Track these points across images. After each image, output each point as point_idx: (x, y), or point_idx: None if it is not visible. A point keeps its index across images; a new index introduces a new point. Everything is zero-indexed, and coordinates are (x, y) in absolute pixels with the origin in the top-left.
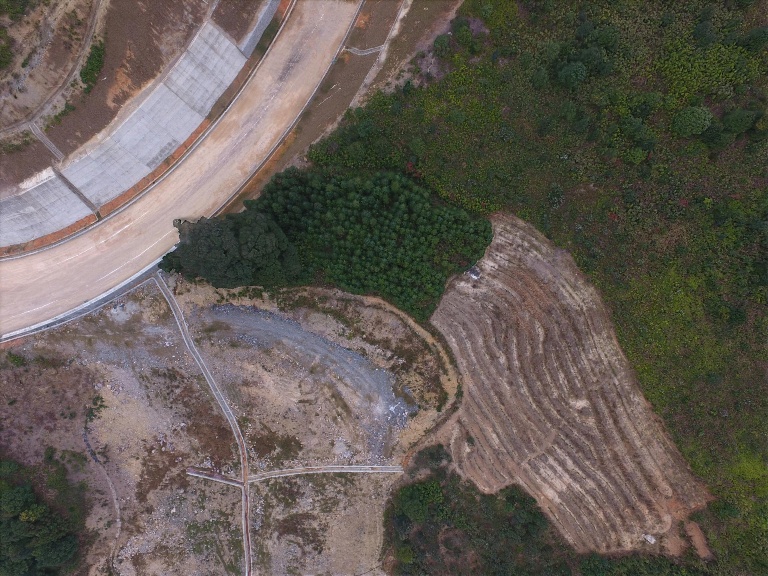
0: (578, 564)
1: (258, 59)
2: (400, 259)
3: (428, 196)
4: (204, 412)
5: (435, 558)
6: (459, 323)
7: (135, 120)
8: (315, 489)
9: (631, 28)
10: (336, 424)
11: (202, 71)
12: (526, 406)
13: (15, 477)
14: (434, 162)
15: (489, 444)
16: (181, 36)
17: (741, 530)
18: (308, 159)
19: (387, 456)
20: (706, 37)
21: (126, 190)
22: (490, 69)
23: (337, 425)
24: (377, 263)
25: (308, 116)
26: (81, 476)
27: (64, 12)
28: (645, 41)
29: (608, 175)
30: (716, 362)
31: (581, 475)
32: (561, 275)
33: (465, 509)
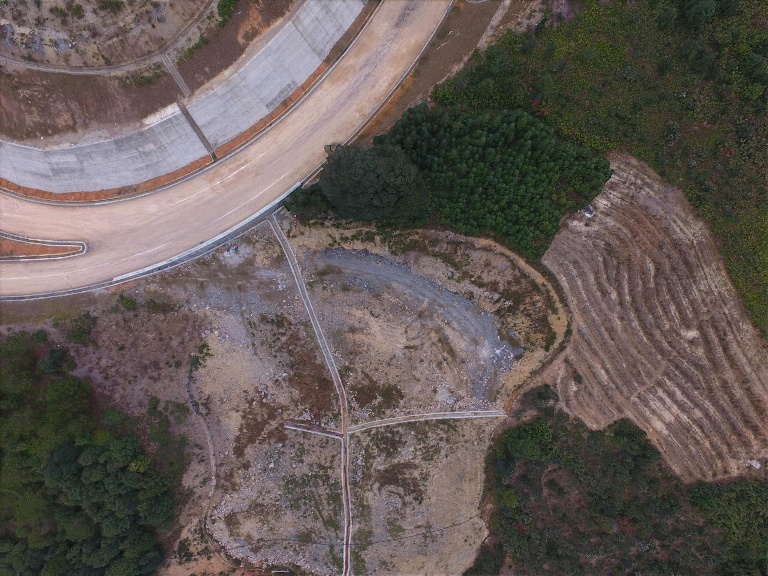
0: (687, 493)
1: (374, 6)
2: (520, 197)
3: None
4: (308, 361)
5: (540, 500)
6: (570, 262)
7: (262, 58)
8: (417, 437)
9: None
10: (440, 370)
11: (326, 13)
12: (637, 339)
13: (118, 428)
14: (556, 102)
15: (598, 380)
16: None
17: None
18: (431, 99)
19: (491, 400)
20: None
21: (243, 131)
22: (619, 9)
23: (441, 371)
24: (496, 202)
25: (426, 60)
26: (182, 429)
27: None
28: None
29: (724, 111)
30: None
31: (689, 405)
32: (673, 211)
33: (573, 447)
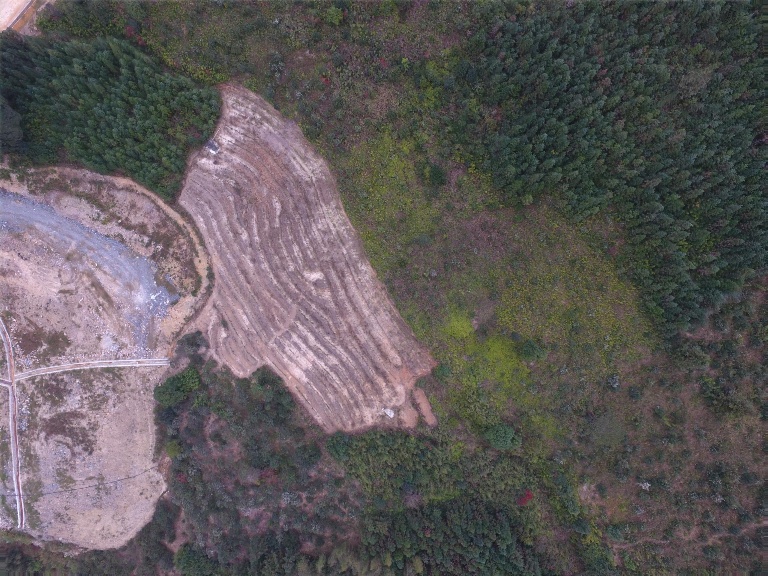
0: (324, 443)
1: None
2: (133, 130)
3: (151, 62)
4: None
5: (200, 451)
6: (206, 202)
7: None
8: (82, 386)
9: None
10: (100, 316)
11: None
12: (267, 282)
13: None
14: None
15: (240, 326)
16: None
17: (458, 392)
18: (38, 28)
19: (152, 348)
20: None
21: None
22: None
23: (101, 317)
24: None
25: None
26: None
27: None
28: None
29: (315, 38)
30: (426, 224)
31: (323, 351)
32: (291, 146)
33: None
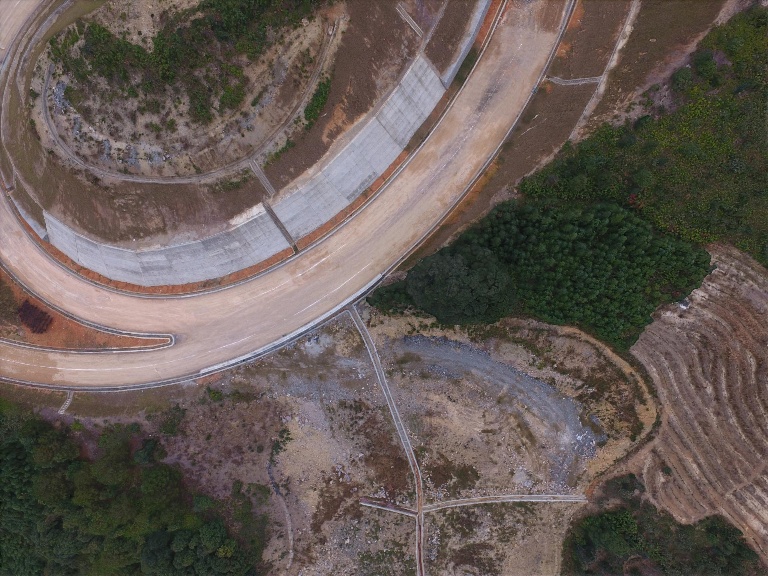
0: None
1: (456, 90)
2: (612, 290)
3: None
4: (384, 443)
5: None
6: (661, 353)
7: (346, 154)
8: (493, 519)
9: None
10: (518, 453)
11: (408, 104)
12: (735, 437)
13: (205, 512)
14: (653, 193)
15: (689, 474)
16: (395, 70)
17: None
18: (518, 191)
19: (571, 485)
20: None
21: (324, 223)
22: (729, 101)
23: (519, 454)
24: (585, 294)
25: (510, 147)
26: (263, 509)
27: (299, 51)
28: None
29: None
30: None
31: None
32: None
33: (659, 540)
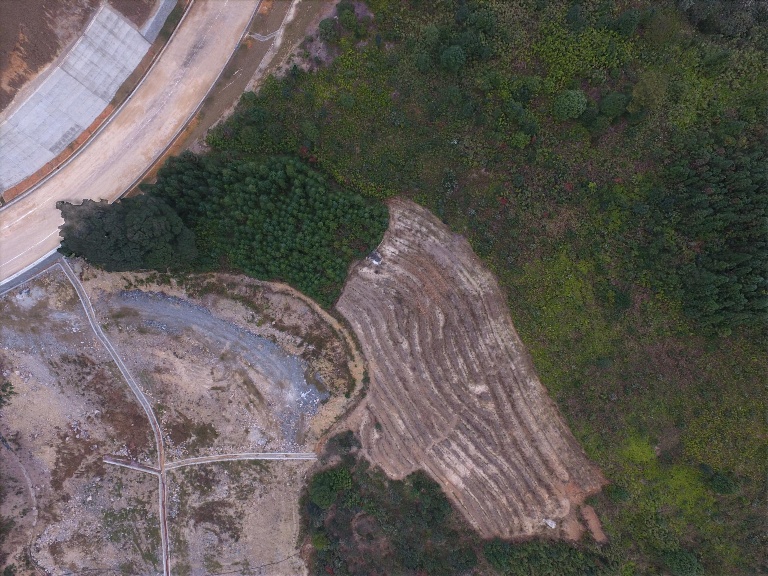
0: (482, 549)
1: (162, 45)
2: (300, 244)
3: (323, 181)
4: (117, 399)
5: (348, 545)
6: (364, 309)
7: (33, 104)
8: (230, 476)
9: (508, 12)
10: (249, 411)
11: (102, 56)
12: (428, 391)
13: None
14: (330, 147)
15: (395, 430)
16: (77, 20)
17: (633, 513)
18: (207, 144)
19: (300, 443)
20: (578, 21)
21: (30, 175)
22: (376, 53)
23: (250, 412)
24: (278, 248)
25: (211, 102)
26: None
27: None
28: (522, 25)
29: (496, 160)
30: (605, 346)
31: (483, 460)
32: (458, 260)
33: (374, 495)
